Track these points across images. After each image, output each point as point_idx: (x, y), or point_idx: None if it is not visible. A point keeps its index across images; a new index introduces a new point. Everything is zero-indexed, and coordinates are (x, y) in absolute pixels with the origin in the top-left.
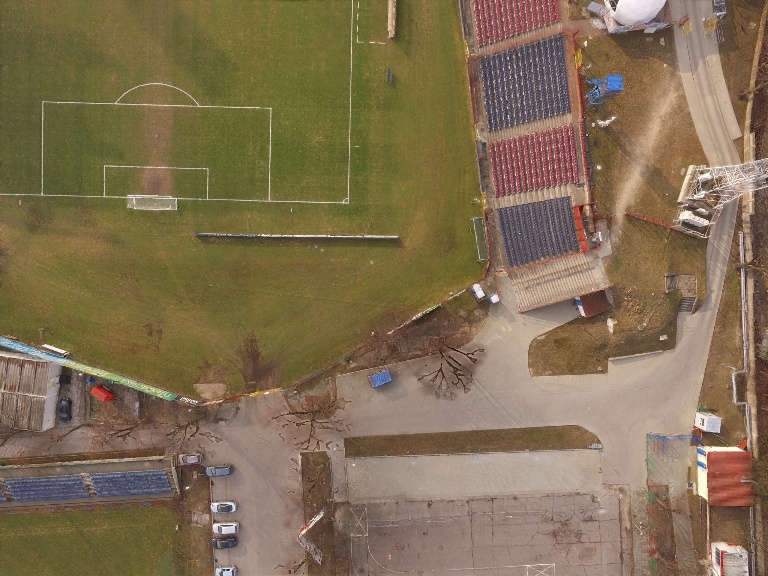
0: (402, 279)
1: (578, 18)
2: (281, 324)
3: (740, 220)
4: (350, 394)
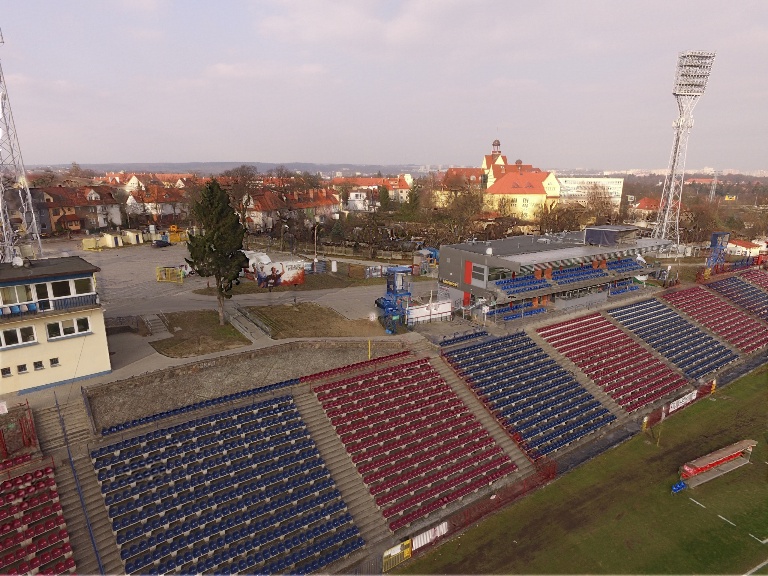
0: None
1: None
2: None
3: None
4: None
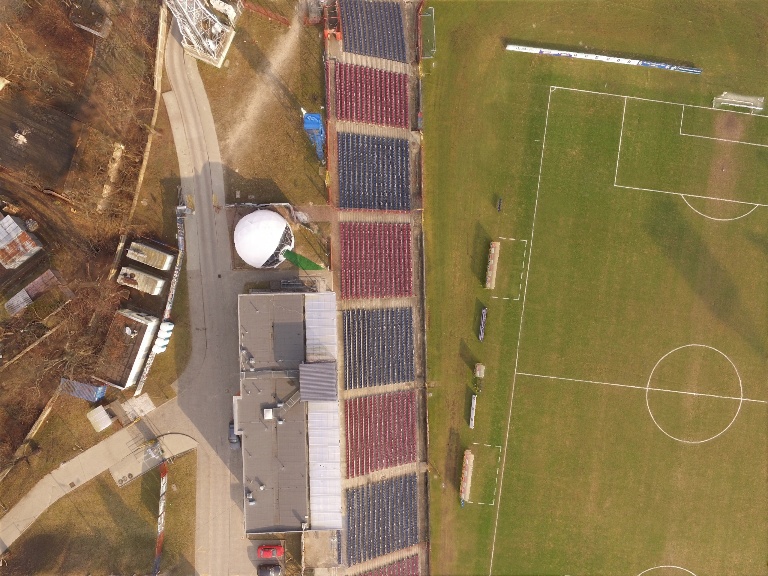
0: (506, 6)
1: (322, 224)
2: None
3: (170, 10)
4: None
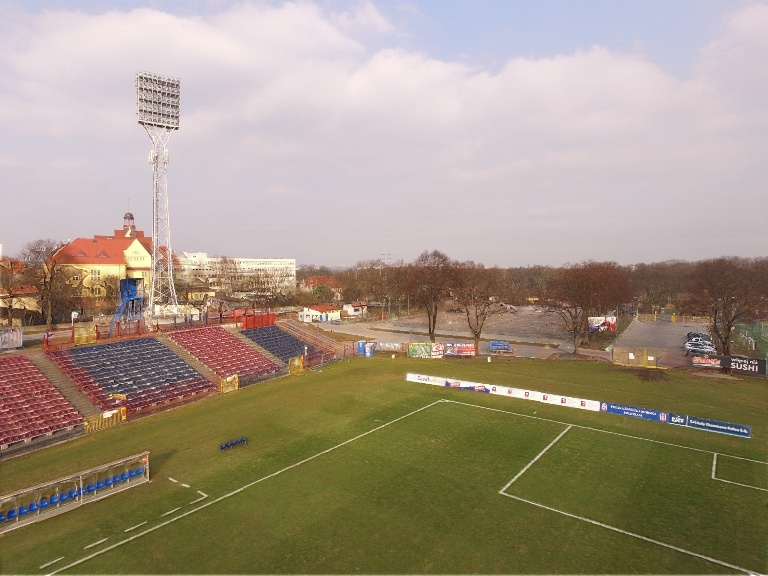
0: None
1: None
2: (599, 378)
3: None
4: (537, 353)
